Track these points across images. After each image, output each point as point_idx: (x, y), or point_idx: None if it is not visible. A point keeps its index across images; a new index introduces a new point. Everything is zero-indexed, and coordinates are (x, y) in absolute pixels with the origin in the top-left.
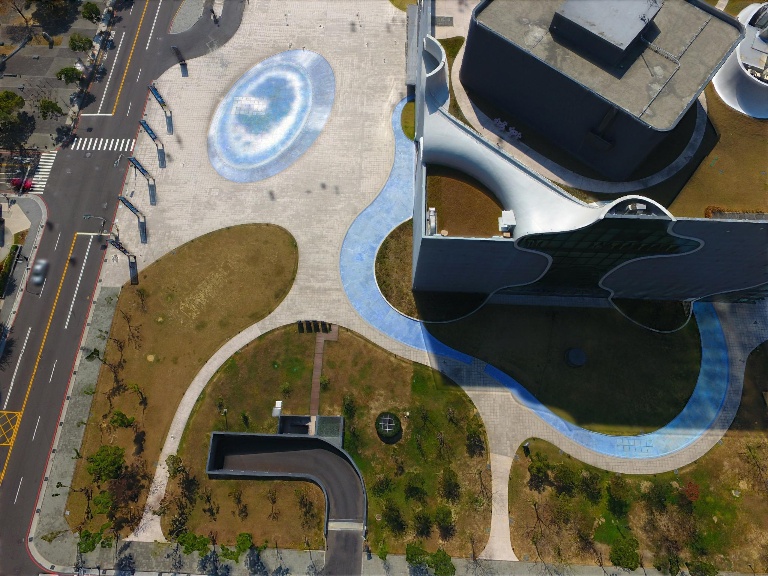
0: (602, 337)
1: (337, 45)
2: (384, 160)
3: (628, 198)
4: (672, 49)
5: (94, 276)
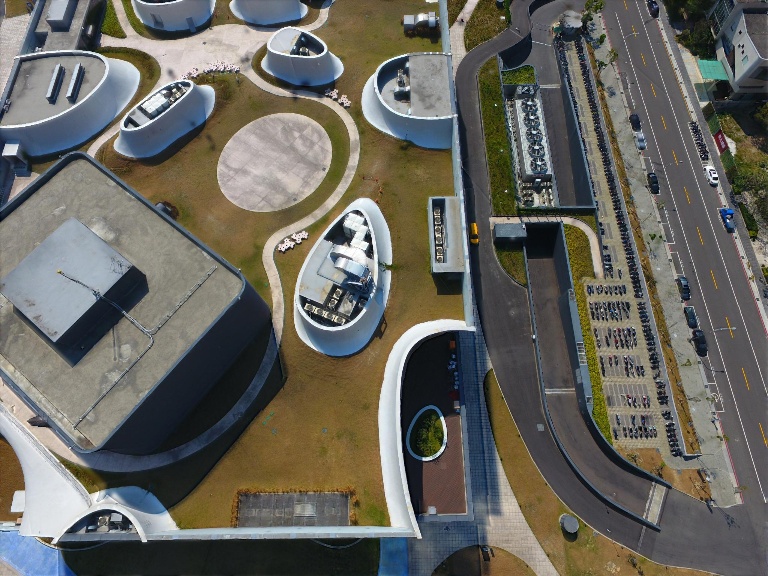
0: (266, 558)
1: None
2: None
3: (97, 509)
4: (153, 317)
5: None
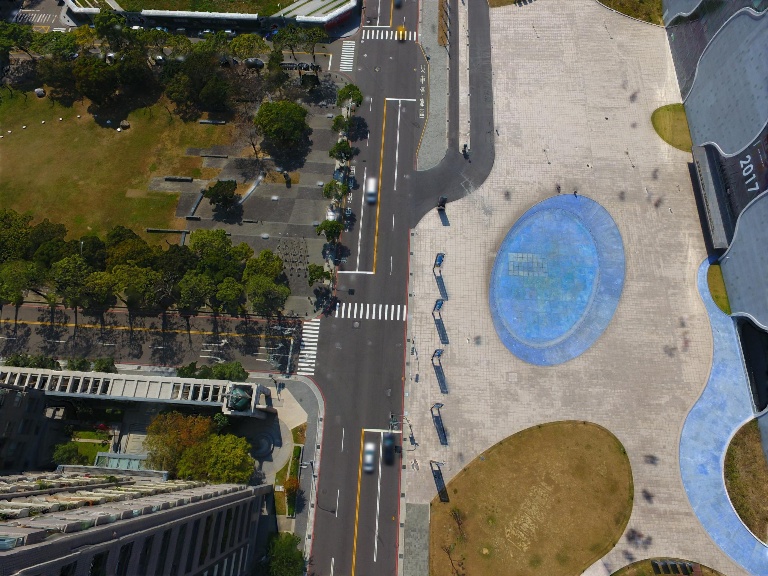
0: None
1: (612, 190)
2: (701, 340)
3: None
4: None
5: (395, 488)
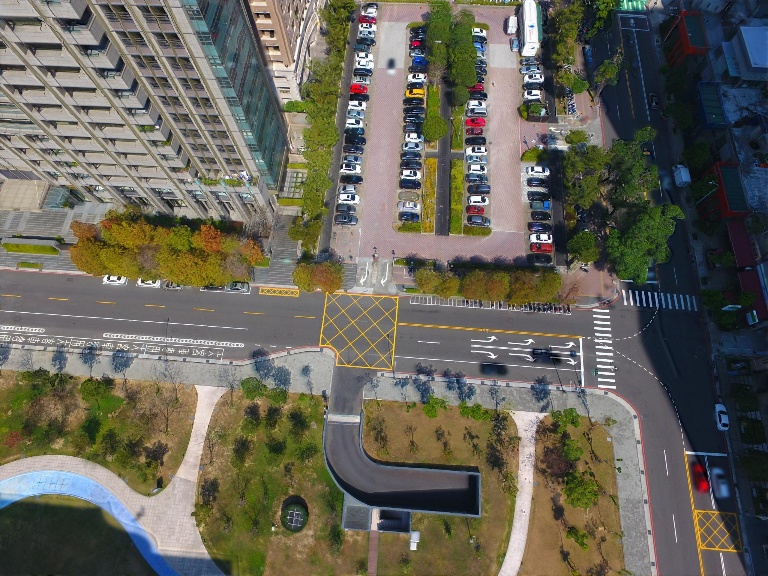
0: None
1: None
2: None
3: None
4: None
5: None
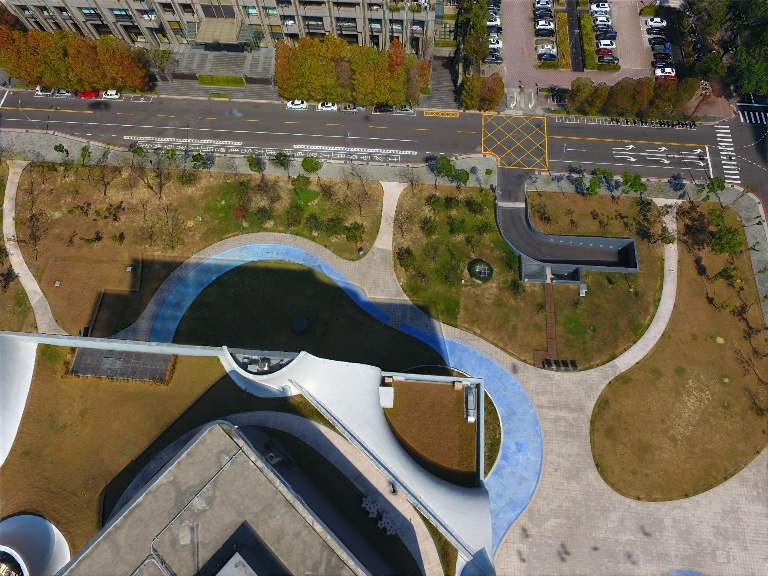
0: (268, 345)
1: None
2: None
3: (266, 376)
4: None
5: None
